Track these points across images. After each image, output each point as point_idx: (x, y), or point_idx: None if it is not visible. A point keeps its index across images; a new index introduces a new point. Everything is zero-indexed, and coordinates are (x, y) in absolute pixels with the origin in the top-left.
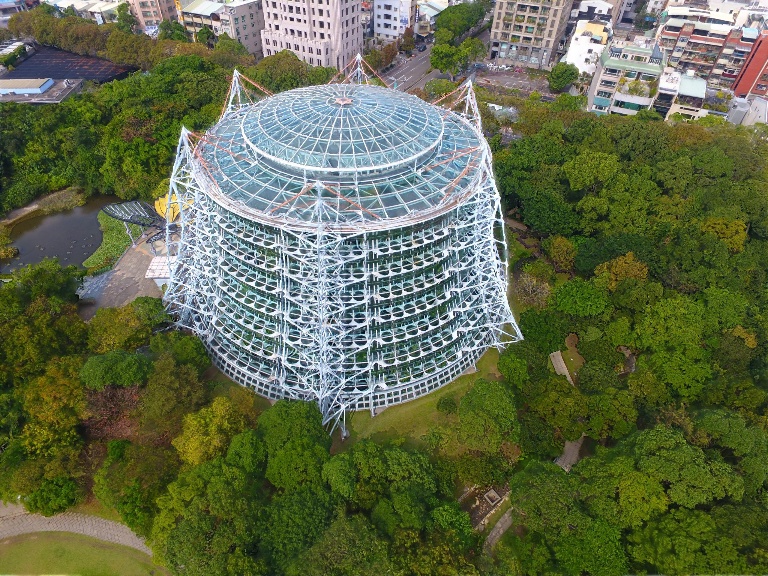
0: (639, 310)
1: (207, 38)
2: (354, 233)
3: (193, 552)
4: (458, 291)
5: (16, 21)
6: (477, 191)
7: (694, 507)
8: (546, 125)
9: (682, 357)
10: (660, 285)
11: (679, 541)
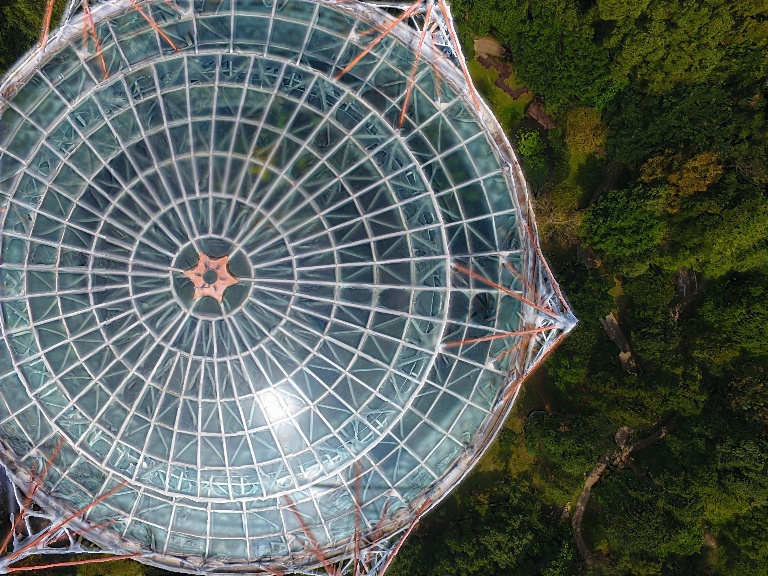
0: (709, 245)
1: None
2: (404, 530)
3: None
4: None
5: None
6: (537, 321)
7: None
8: None
9: (761, 311)
10: (746, 215)
11: (760, 544)
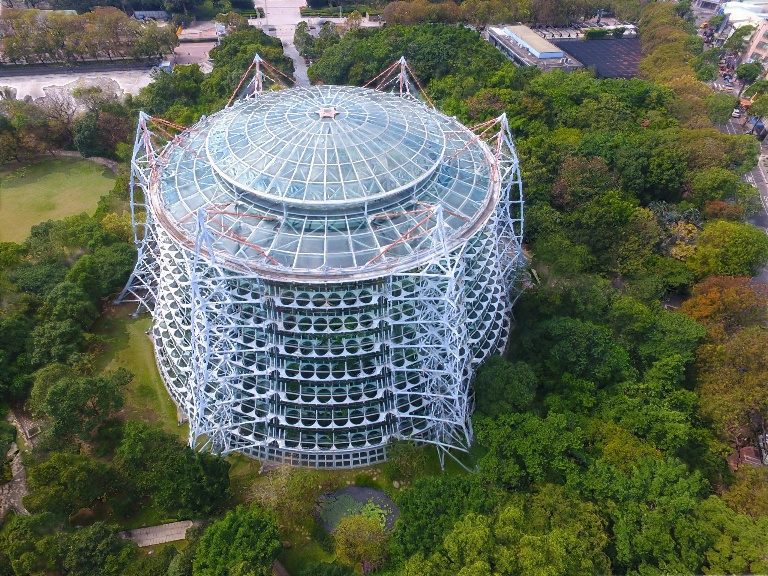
0: None
1: (761, 93)
2: None
3: None
4: None
5: (650, 8)
6: None
7: None
8: (766, 524)
9: None
10: None
11: None
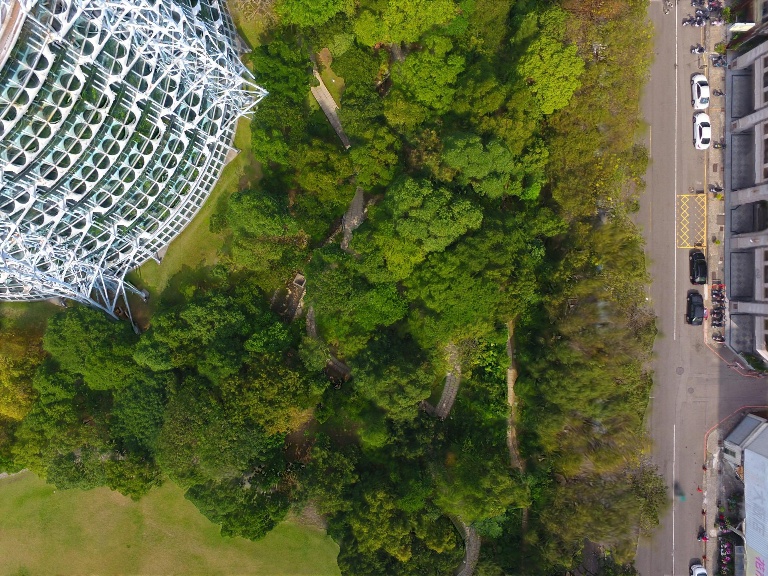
0: None
1: None
2: None
3: (74, 483)
4: (145, 98)
5: None
6: None
7: (444, 249)
8: None
9: (431, 59)
10: None
11: (433, 288)
